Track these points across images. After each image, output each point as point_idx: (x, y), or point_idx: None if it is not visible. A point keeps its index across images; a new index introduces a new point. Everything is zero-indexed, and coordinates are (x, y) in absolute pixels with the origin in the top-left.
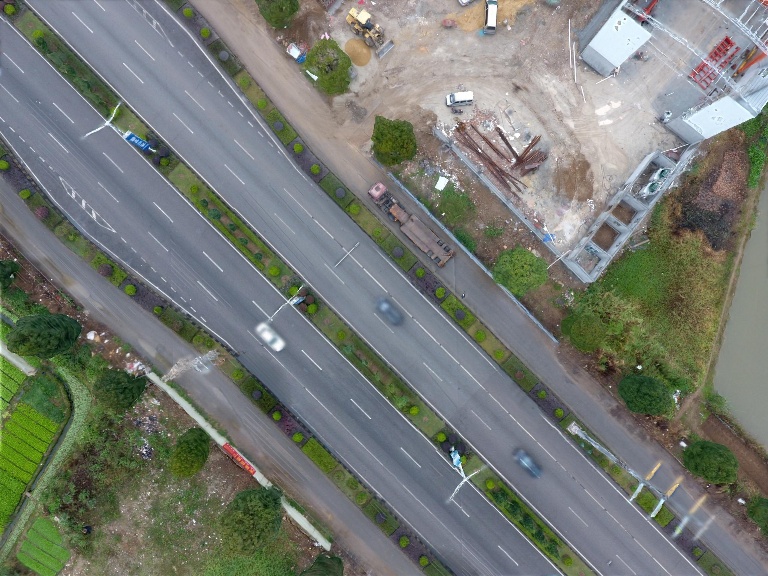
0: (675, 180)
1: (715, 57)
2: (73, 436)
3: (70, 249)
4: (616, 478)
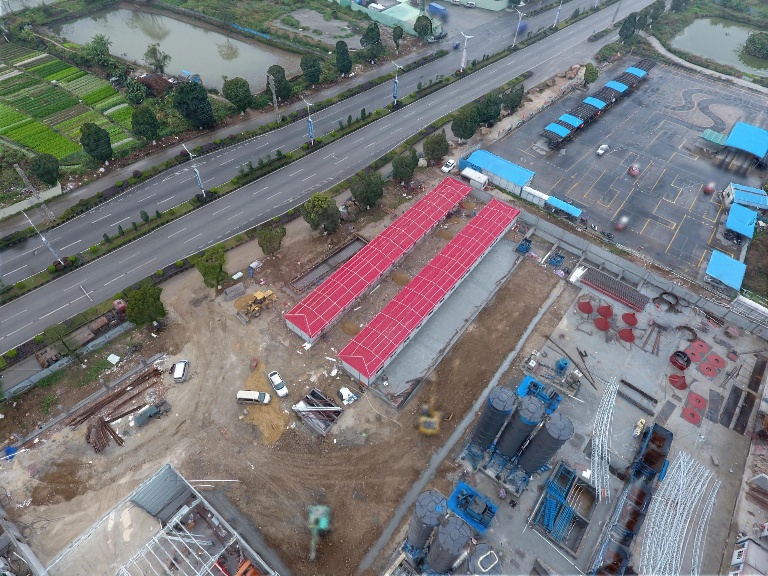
0: None
1: None
2: None
3: None
4: None
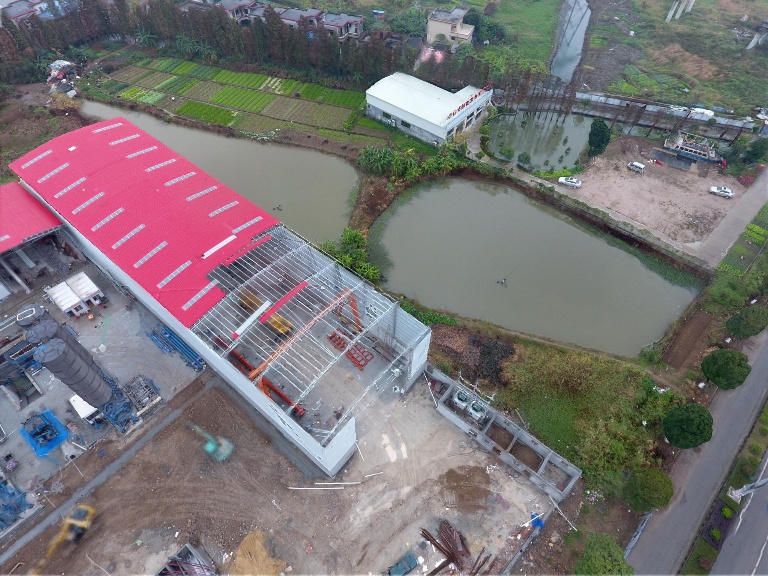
0: None
1: None
2: None
3: None
4: (763, 450)
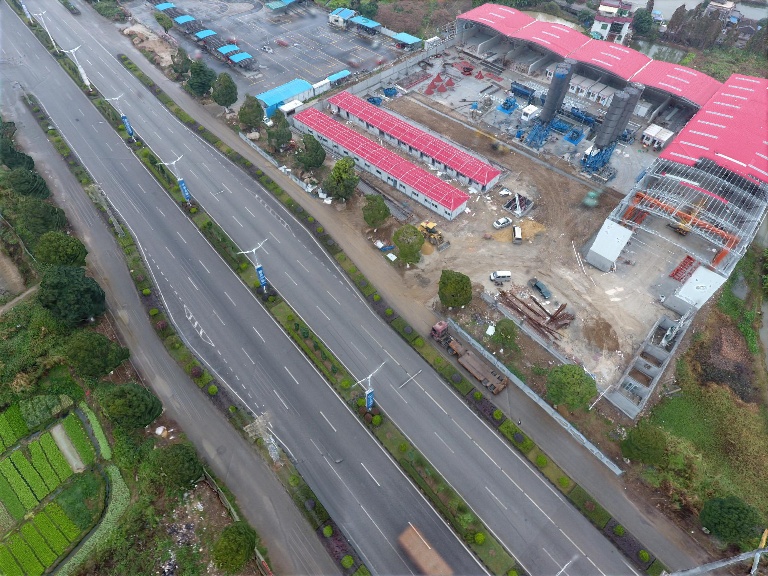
0: (686, 343)
1: (684, 266)
2: (91, 547)
3: (171, 356)
4: None
